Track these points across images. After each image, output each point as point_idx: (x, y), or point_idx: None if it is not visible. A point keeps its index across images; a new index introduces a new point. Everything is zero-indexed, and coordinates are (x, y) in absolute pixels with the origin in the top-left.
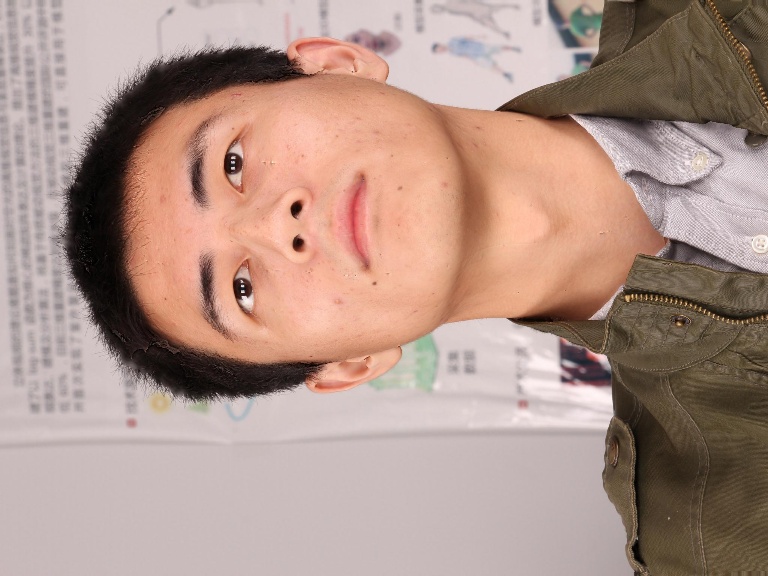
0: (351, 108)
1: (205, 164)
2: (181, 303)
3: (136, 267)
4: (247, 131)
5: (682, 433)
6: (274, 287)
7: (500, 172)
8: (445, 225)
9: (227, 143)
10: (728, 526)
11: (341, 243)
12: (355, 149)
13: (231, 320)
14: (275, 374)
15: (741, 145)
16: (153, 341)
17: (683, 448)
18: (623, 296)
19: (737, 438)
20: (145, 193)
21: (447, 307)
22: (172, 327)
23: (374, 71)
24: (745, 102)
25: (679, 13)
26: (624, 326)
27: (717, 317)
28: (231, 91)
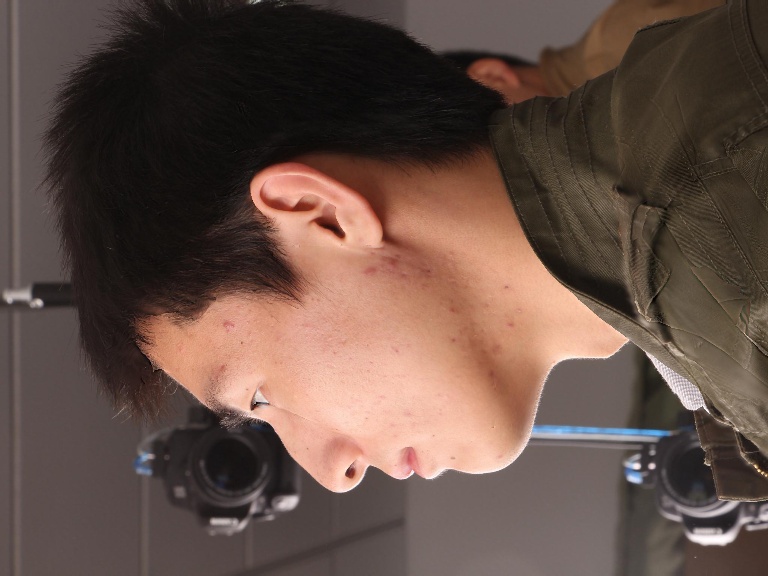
0: (370, 386)
1: (231, 408)
2: None
3: None
4: None
5: None
6: None
7: (546, 334)
8: None
9: (248, 404)
10: None
11: None
12: (392, 435)
13: None
14: None
15: None
16: None
17: None
18: None
19: None
20: None
21: None
22: None
23: (365, 237)
24: None
25: None
26: None
27: None
28: (219, 311)
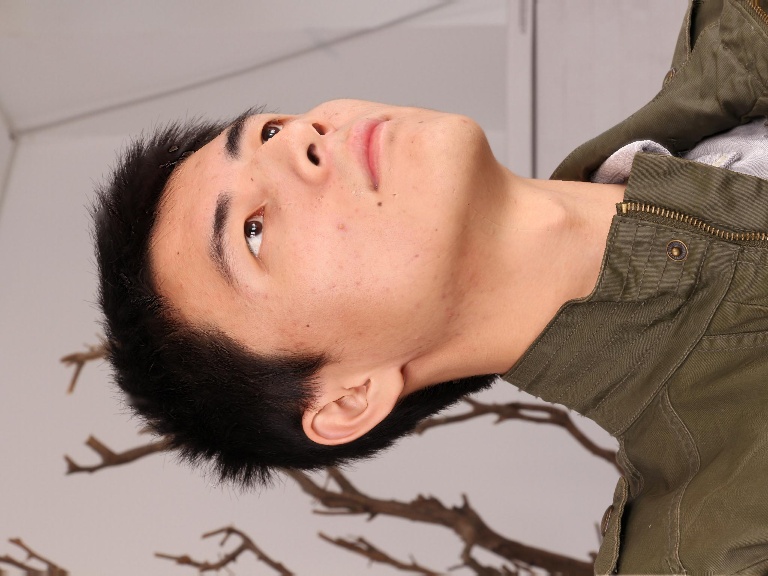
0: None
1: (245, 131)
2: (192, 251)
3: (158, 235)
4: None
5: (677, 458)
6: (283, 222)
7: (526, 185)
8: (457, 147)
9: (270, 118)
10: (707, 491)
11: (354, 153)
12: None
13: (235, 257)
14: (271, 369)
15: (760, 138)
16: (157, 296)
17: (676, 478)
18: (620, 204)
19: (729, 421)
20: (183, 169)
21: (451, 277)
22: (179, 293)
23: None
24: (763, 63)
25: None
26: (621, 268)
27: (712, 229)
28: None
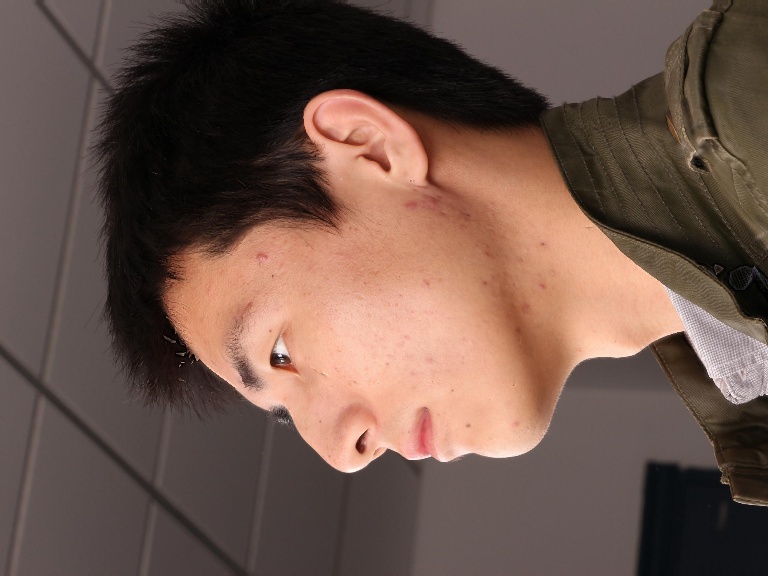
0: (396, 322)
1: (250, 363)
2: None
3: None
4: (286, 328)
5: None
6: None
7: (575, 307)
8: (524, 448)
9: (268, 351)
10: None
11: None
12: (410, 385)
13: None
14: None
15: None
16: None
17: None
18: None
19: None
20: (192, 344)
21: None
22: None
23: (410, 170)
24: None
25: (754, 322)
26: None
27: None
28: (255, 242)
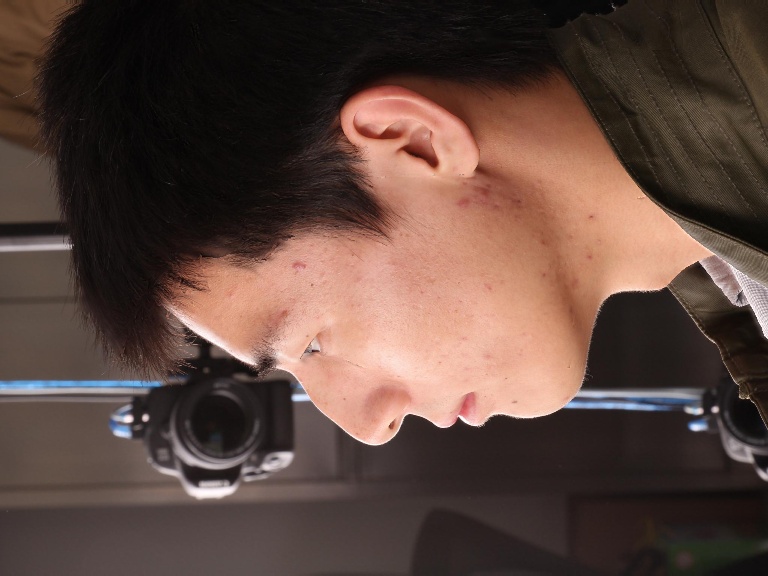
0: (454, 327)
1: None
2: None
3: None
4: (323, 330)
5: None
6: None
7: (616, 267)
8: None
9: (302, 352)
10: None
11: None
12: (463, 379)
13: None
14: None
15: None
16: None
17: None
18: None
19: None
20: None
21: None
22: None
23: (461, 166)
24: None
25: None
26: None
27: None
28: (289, 251)
